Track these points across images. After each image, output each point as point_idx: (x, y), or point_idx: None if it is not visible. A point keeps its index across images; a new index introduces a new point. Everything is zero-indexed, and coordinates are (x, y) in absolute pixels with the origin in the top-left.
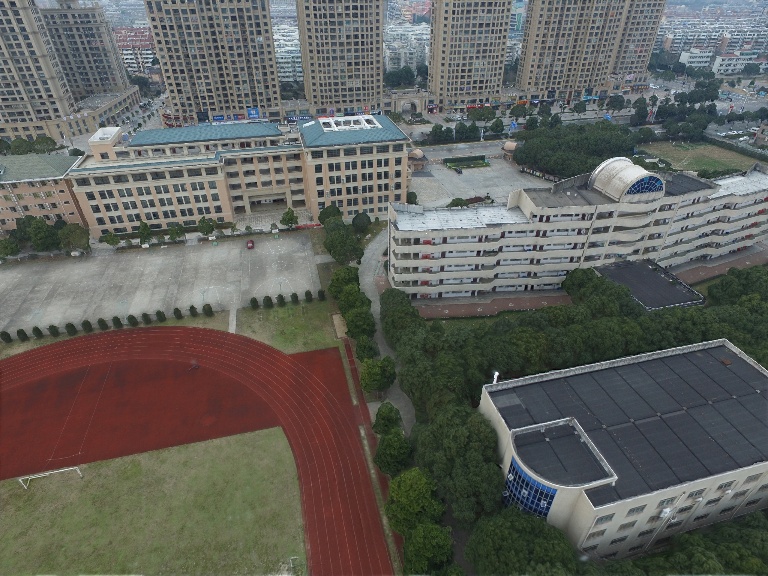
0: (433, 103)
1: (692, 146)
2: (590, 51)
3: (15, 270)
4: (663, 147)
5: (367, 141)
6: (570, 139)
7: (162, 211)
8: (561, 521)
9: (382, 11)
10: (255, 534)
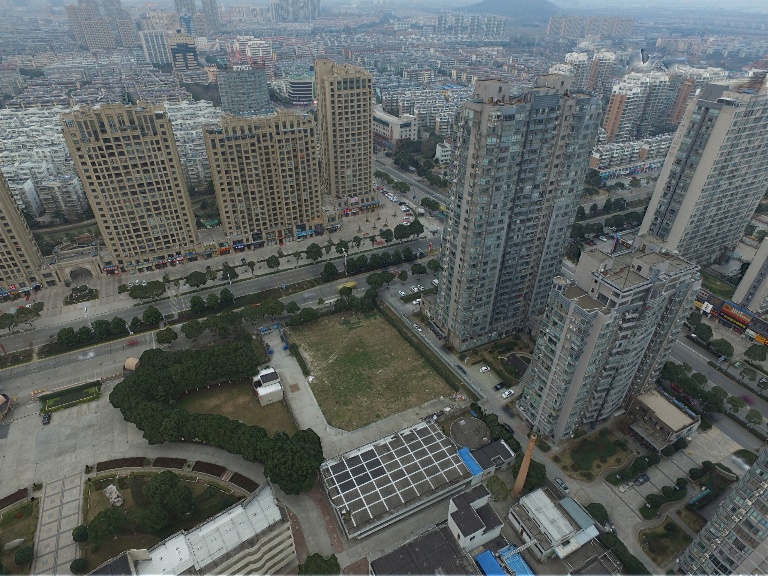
0: (112, 264)
1: (359, 321)
2: (289, 191)
3: None
4: (328, 327)
5: None
6: (173, 371)
7: None
8: None
9: (1, 183)
10: None
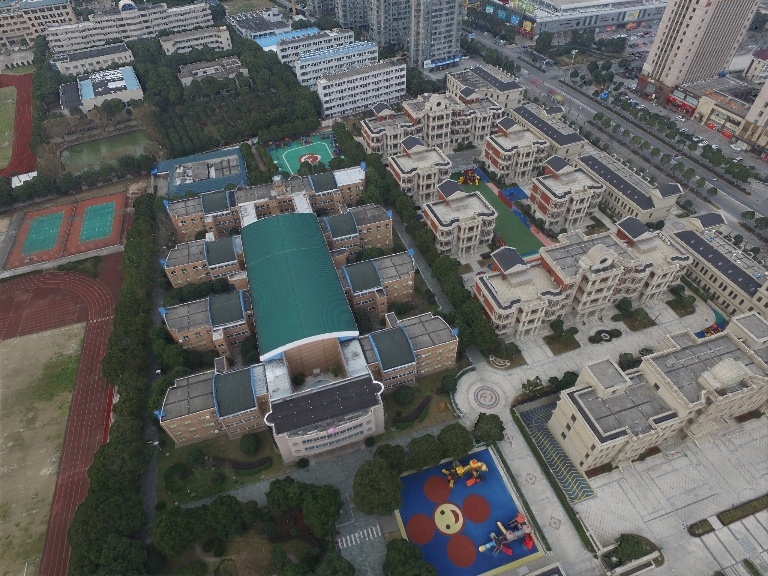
0: None
1: None
2: None
3: None
4: (237, 1)
5: (48, 5)
6: None
7: None
8: (64, 74)
9: None
10: (4, 97)
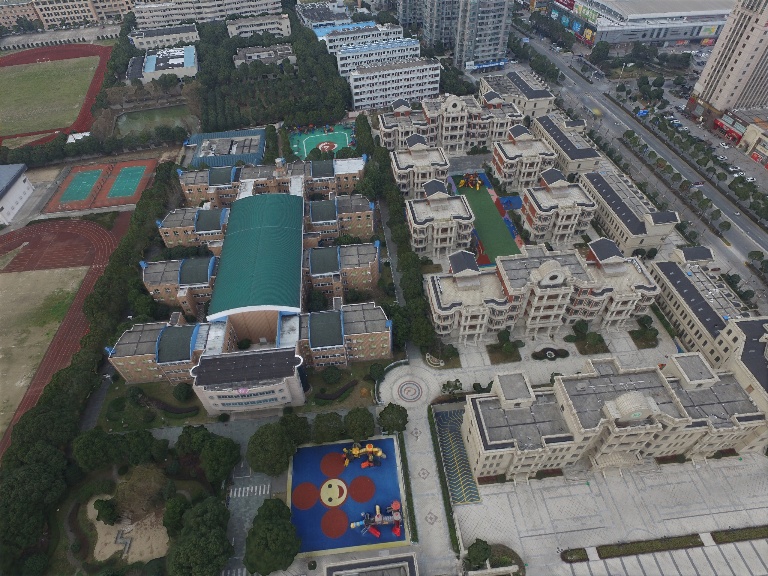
0: None
1: None
2: None
3: (20, 36)
4: None
5: None
6: None
7: (69, 17)
8: (138, 48)
9: None
10: None
